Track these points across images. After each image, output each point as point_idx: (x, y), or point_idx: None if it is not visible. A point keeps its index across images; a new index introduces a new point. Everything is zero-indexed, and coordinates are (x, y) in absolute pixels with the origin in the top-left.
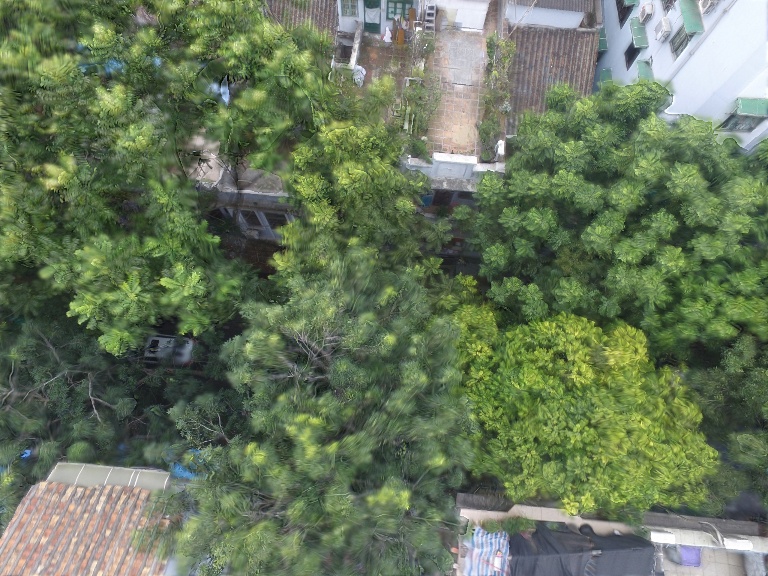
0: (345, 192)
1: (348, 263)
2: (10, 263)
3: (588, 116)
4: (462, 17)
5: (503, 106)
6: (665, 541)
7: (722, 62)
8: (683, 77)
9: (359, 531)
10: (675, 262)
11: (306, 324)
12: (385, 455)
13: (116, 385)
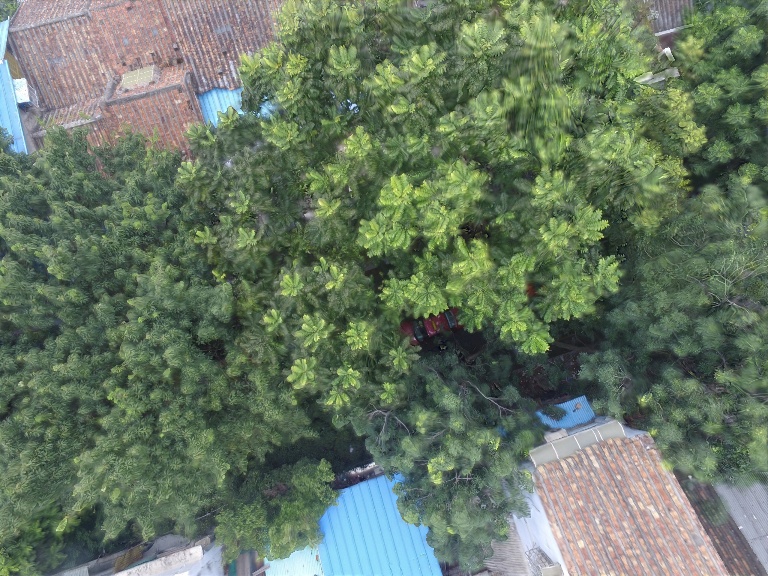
0: (684, 145)
1: (730, 201)
2: (396, 319)
3: None
4: None
5: (652, 15)
6: None
7: None
8: None
9: None
10: None
11: (726, 261)
12: None
13: (477, 383)
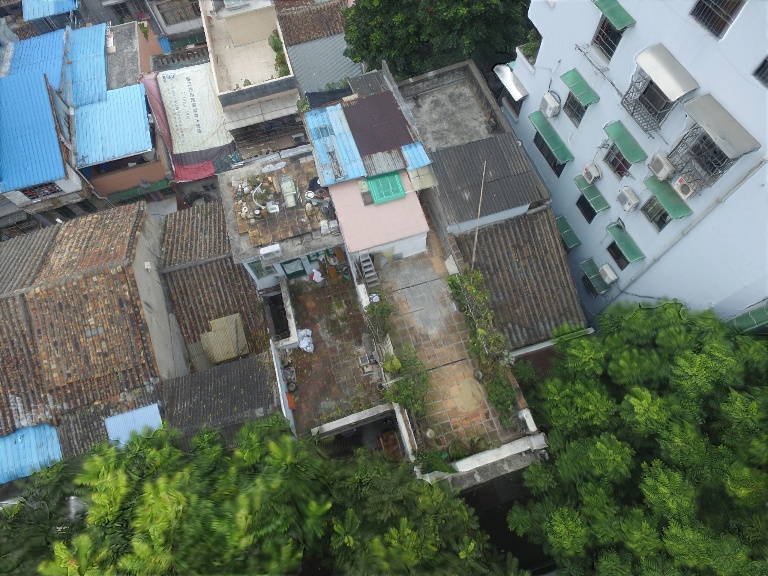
0: None
1: None
2: None
3: (656, 418)
4: (400, 249)
5: (505, 361)
6: None
7: (740, 254)
8: (682, 254)
9: None
10: None
11: None
12: None
13: None
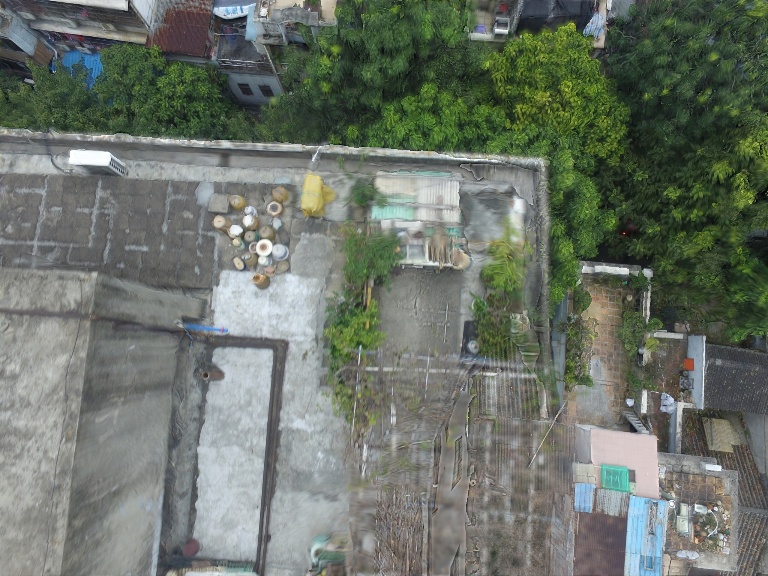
0: None
1: None
2: None
3: None
4: None
5: None
6: (501, 30)
7: None
8: None
9: (697, 3)
10: (518, 138)
11: (766, 66)
12: (688, 35)
13: None
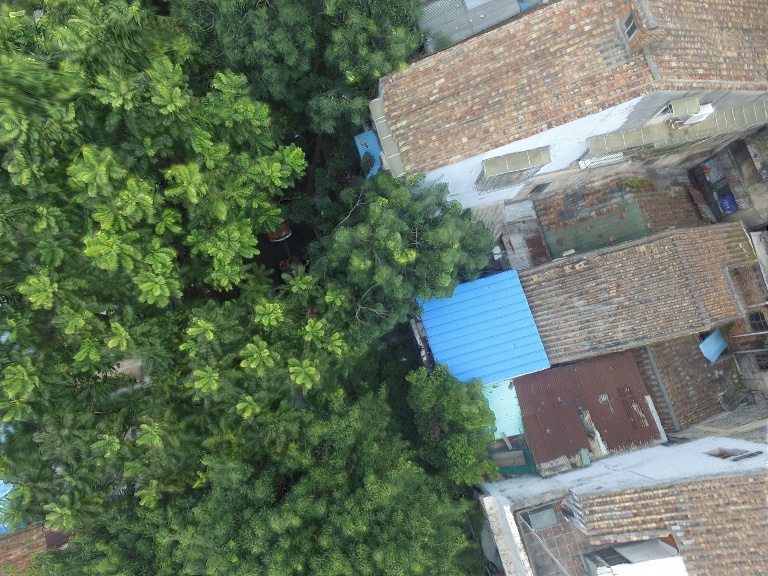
0: None
1: None
2: None
3: None
4: None
5: None
6: None
7: None
8: None
9: None
10: None
11: None
12: None
13: None
